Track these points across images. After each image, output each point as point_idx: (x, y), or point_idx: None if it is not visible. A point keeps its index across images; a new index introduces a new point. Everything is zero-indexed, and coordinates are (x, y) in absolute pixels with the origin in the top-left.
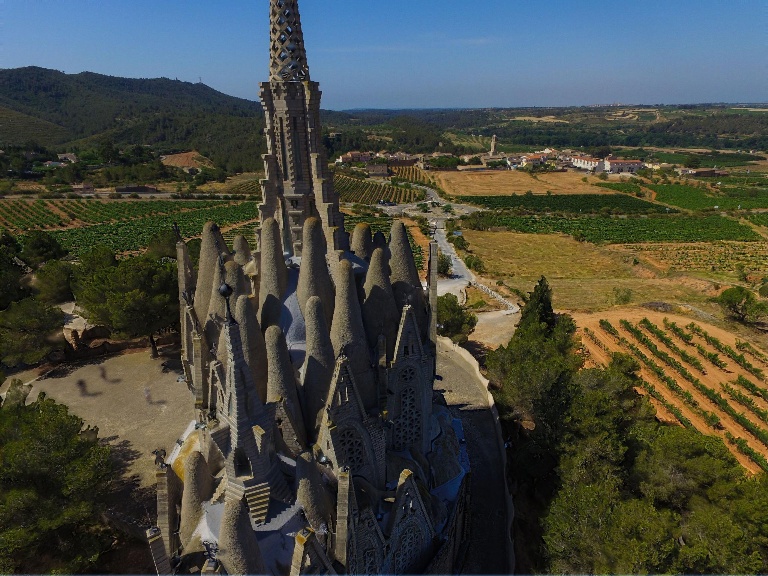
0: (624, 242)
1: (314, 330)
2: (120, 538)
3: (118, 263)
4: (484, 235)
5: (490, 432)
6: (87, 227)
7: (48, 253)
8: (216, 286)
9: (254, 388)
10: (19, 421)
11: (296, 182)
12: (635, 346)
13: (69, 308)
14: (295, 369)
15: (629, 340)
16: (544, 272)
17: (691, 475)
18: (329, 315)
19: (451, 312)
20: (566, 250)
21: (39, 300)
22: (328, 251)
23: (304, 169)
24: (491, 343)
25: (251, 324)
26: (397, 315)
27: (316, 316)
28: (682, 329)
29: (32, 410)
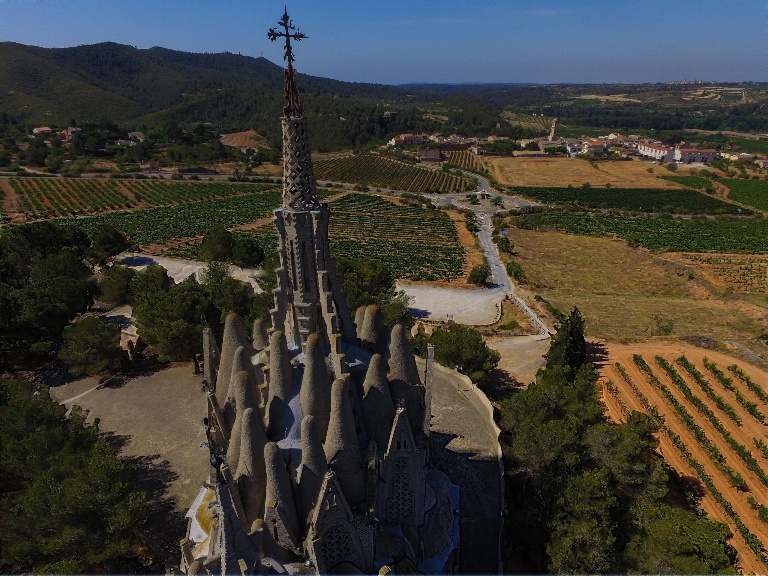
0: (682, 250)
1: (307, 445)
2: (154, 560)
3: (169, 280)
4: (531, 235)
5: (494, 487)
6: (151, 209)
7: (113, 249)
8: (234, 375)
9: (241, 529)
10: (74, 461)
11: (304, 294)
12: (667, 388)
13: (128, 311)
14: (293, 468)
15: (663, 379)
16: (589, 282)
17: (678, 573)
18: (328, 415)
19: (473, 350)
20: (617, 257)
21: (103, 301)
22: (332, 352)
23: (312, 283)
24: (516, 373)
25: (255, 433)
26: (392, 412)
27: (309, 434)
28: (722, 372)
29: (88, 434)
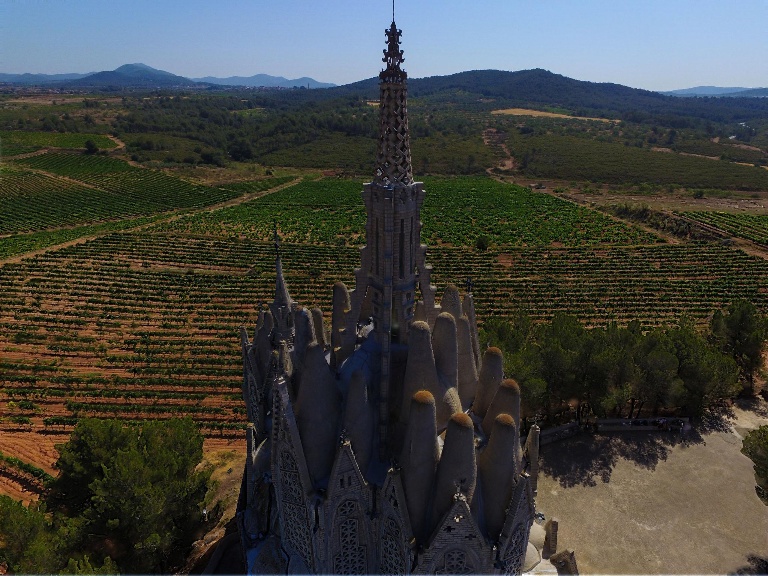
0: None
1: None
2: None
3: None
4: None
5: None
6: None
7: None
8: None
9: None
10: None
11: None
12: None
13: None
14: None
15: None
16: None
17: None
18: None
19: None
20: None
21: None
22: None
23: None
24: None
25: None
26: None
27: None
28: None
29: None
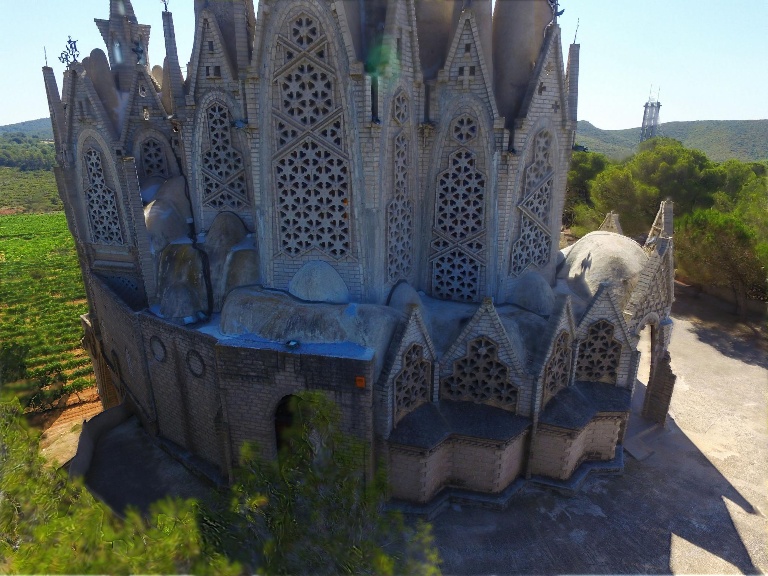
0: None
1: None
2: None
3: None
4: None
5: None
6: None
7: None
8: None
9: None
10: None
11: None
12: None
13: None
14: None
15: None
16: None
17: None
18: None
19: None
20: None
21: None
22: None
23: None
24: None
25: None
26: None
27: None
28: None
29: None
